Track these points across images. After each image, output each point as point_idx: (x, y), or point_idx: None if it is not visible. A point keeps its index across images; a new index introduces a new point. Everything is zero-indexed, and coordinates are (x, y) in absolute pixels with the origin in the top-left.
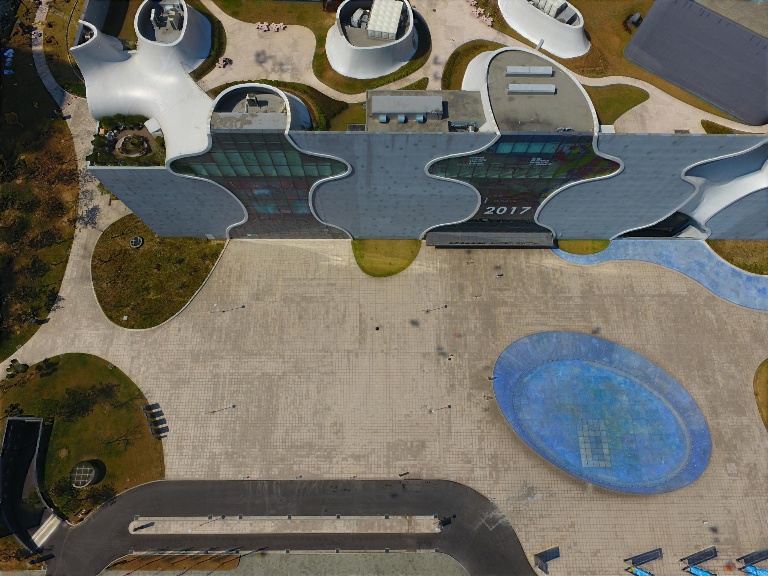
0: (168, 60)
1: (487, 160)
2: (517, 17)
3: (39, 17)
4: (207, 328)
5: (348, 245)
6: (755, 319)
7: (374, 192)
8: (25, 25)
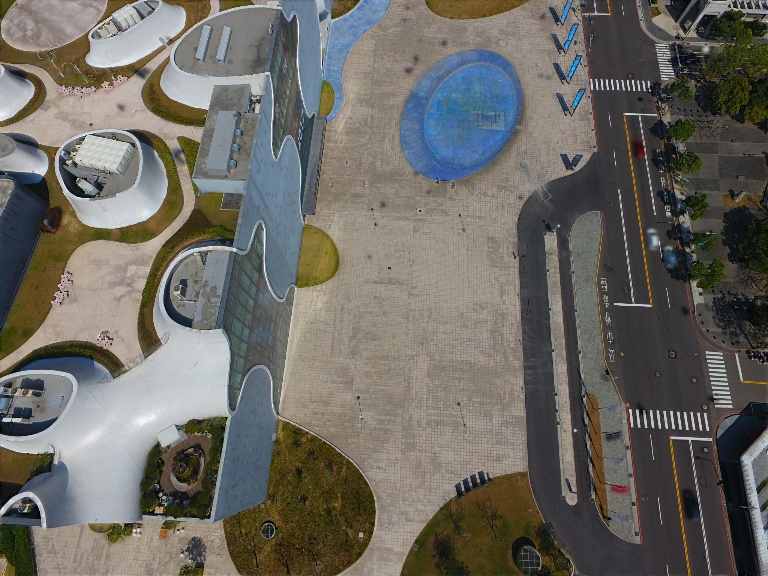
0: (92, 398)
1: (278, 103)
2: (127, 52)
3: None
4: (379, 436)
5: (301, 291)
6: (397, 5)
7: (276, 224)
8: None
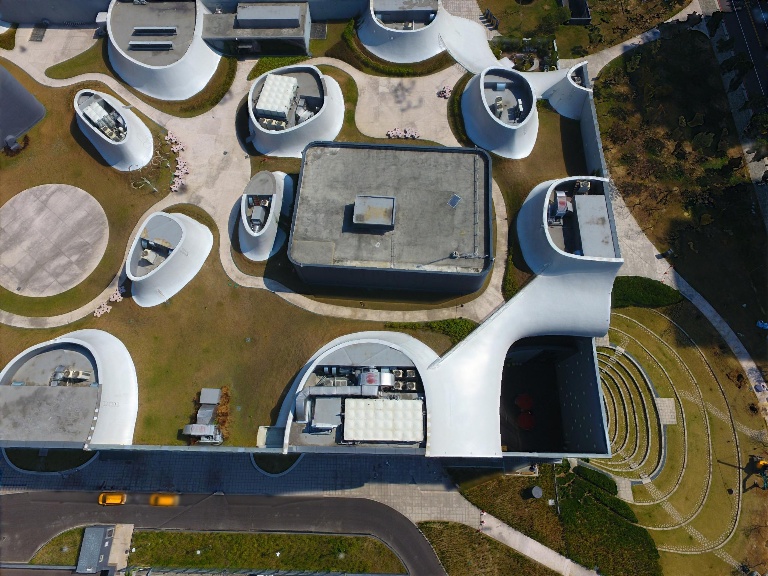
0: None
1: None
2: (139, 128)
3: None
4: None
5: None
6: None
7: None
8: None
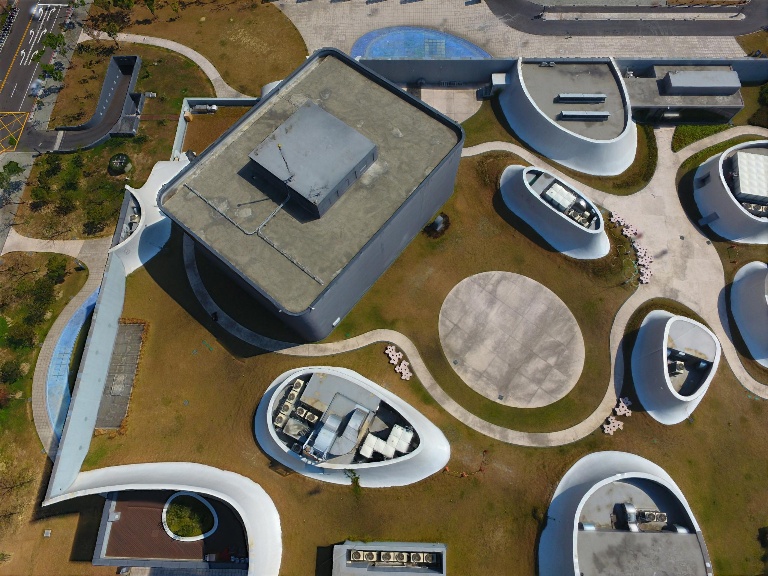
0: None
1: None
2: None
3: None
4: None
5: None
6: None
7: None
8: None
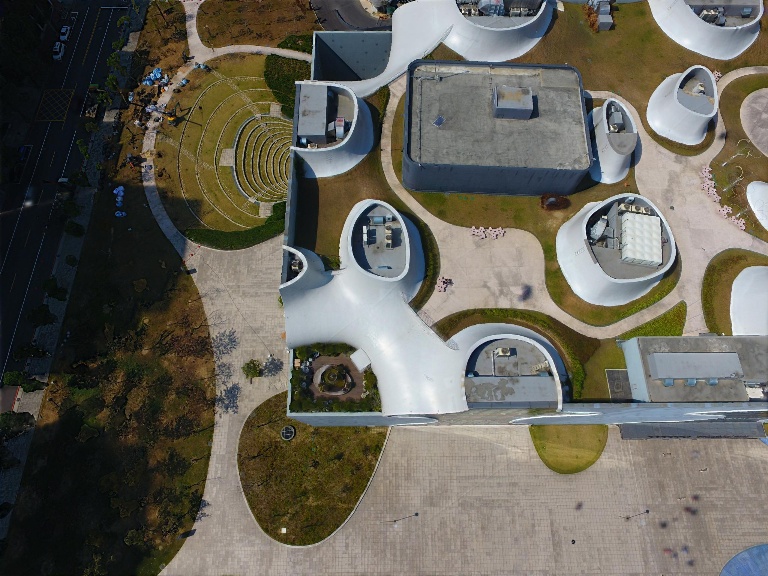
0: (388, 292)
1: None
2: None
3: (147, 145)
4: (378, 543)
5: (526, 433)
6: None
7: None
8: (133, 156)
